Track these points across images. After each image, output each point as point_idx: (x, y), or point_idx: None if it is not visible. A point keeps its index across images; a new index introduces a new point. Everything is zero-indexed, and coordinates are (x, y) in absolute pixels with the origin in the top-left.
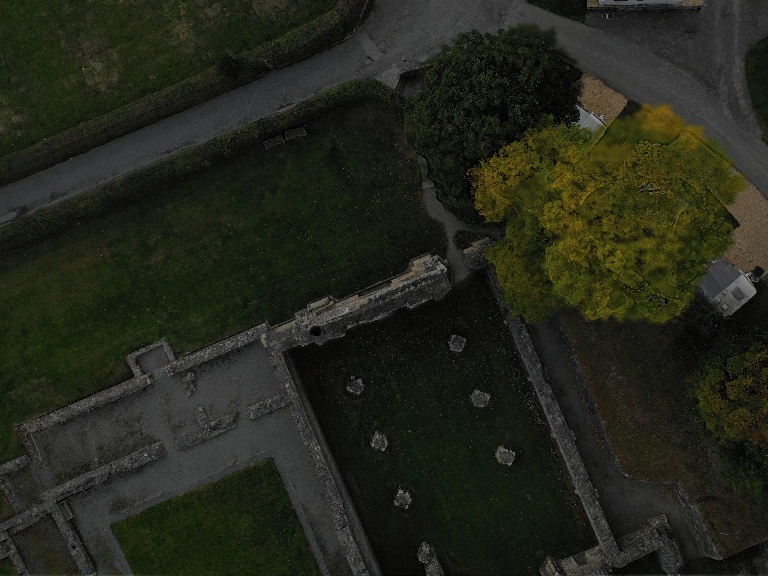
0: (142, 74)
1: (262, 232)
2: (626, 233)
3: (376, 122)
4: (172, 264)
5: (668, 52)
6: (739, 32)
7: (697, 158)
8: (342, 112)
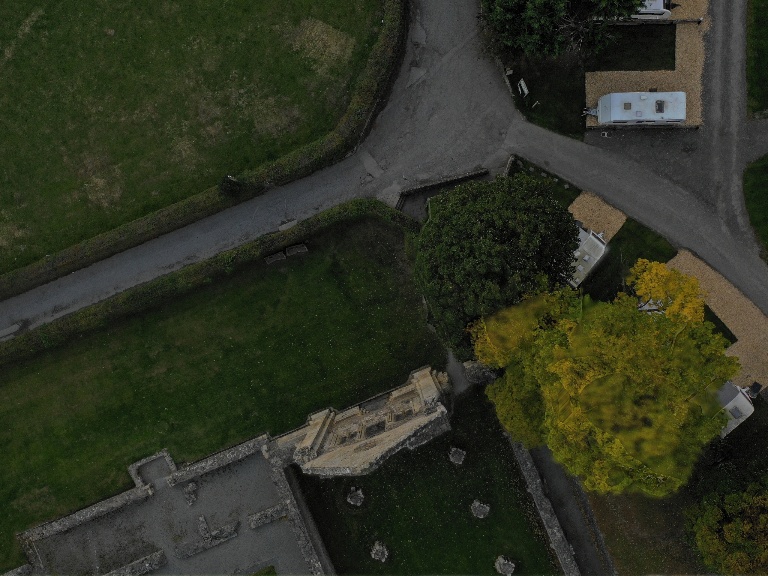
0: (144, 190)
1: (263, 345)
2: (625, 356)
3: (377, 239)
4: (174, 376)
5: (666, 170)
6: (737, 151)
7: (695, 275)
8: (343, 228)
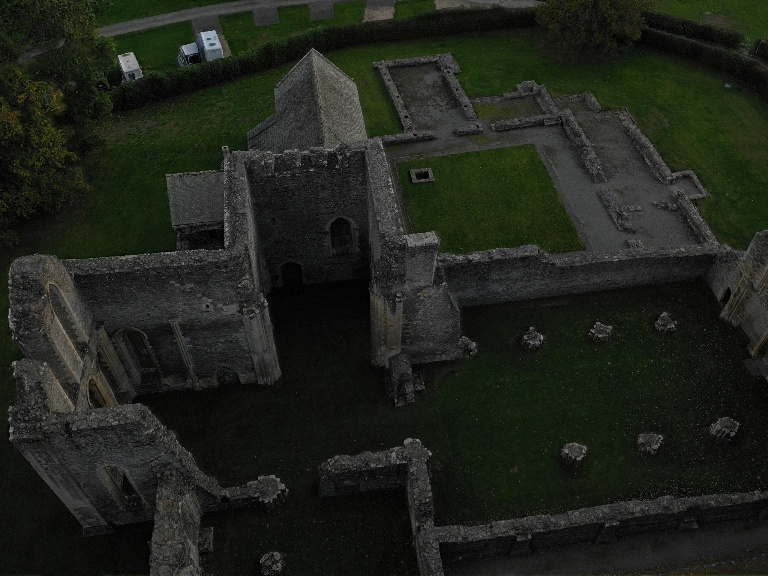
0: None
1: None
2: None
3: None
4: None
5: None
6: None
7: None
8: None
